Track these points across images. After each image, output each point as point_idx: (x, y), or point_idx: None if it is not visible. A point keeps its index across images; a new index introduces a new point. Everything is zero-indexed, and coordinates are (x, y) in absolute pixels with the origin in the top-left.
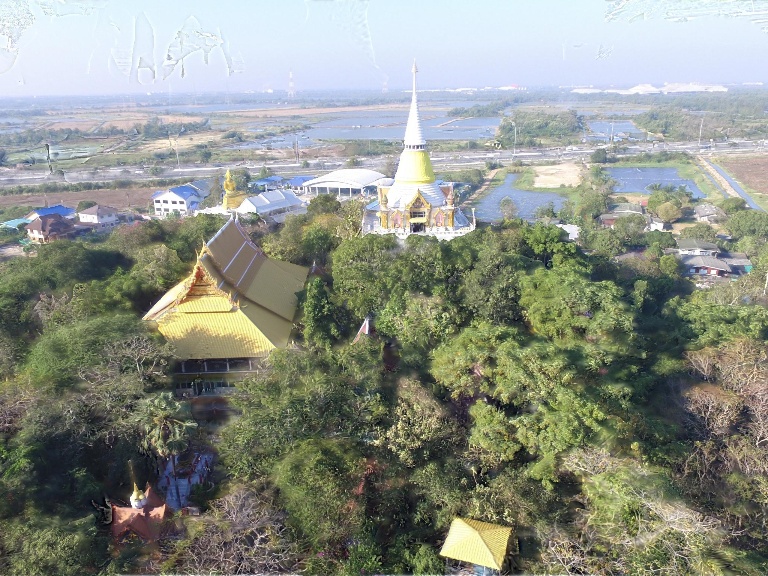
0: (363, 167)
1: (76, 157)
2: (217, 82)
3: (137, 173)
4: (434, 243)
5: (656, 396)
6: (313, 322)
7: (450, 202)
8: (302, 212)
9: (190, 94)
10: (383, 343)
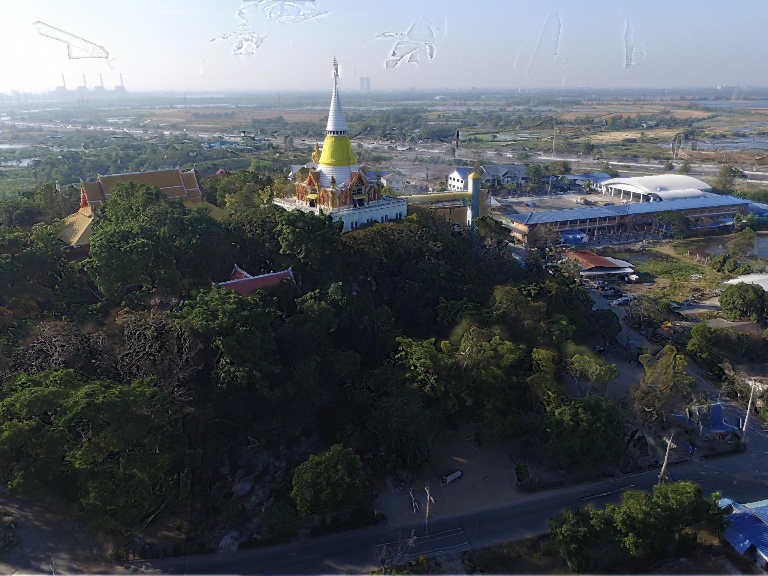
0: (691, 174)
1: (511, 140)
2: (613, 74)
3: (508, 156)
4: (151, 195)
5: None
6: (93, 231)
7: (331, 184)
8: None
9: (582, 86)
10: None
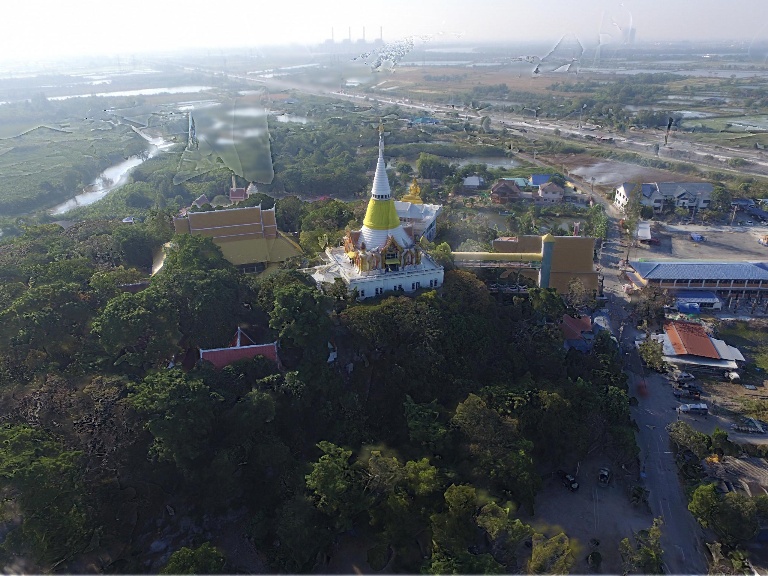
0: None
1: (750, 131)
2: None
3: (720, 160)
4: None
5: (79, 376)
6: None
7: None
8: (420, 226)
9: None
10: (74, 272)
